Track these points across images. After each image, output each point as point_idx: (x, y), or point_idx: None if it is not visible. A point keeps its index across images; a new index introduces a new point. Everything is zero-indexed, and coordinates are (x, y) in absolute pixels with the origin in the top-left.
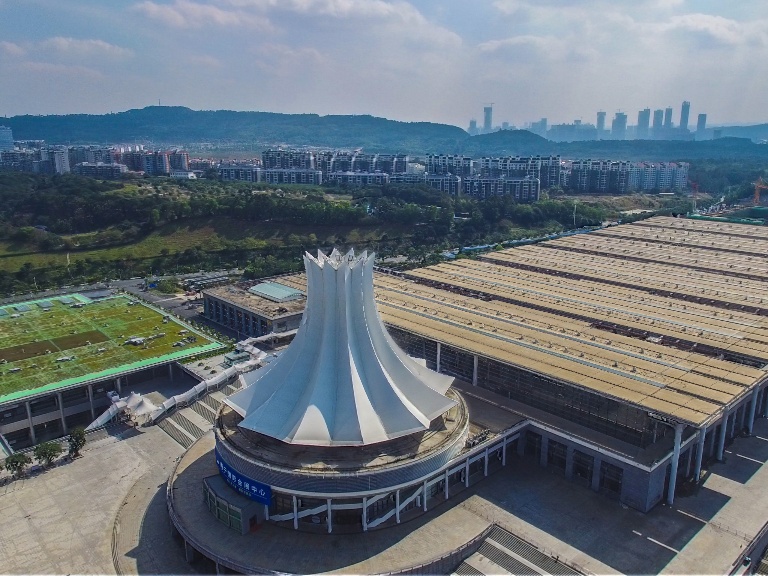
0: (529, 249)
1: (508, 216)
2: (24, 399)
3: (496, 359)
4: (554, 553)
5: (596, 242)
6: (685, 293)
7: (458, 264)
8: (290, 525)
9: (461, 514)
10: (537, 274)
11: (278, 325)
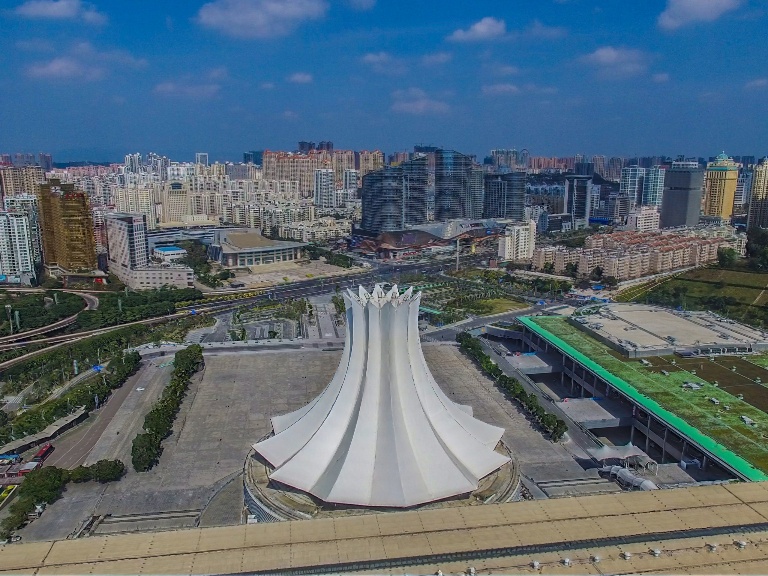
0: None
1: None
2: None
3: None
4: None
5: None
6: None
7: None
8: None
9: None
10: None
11: None
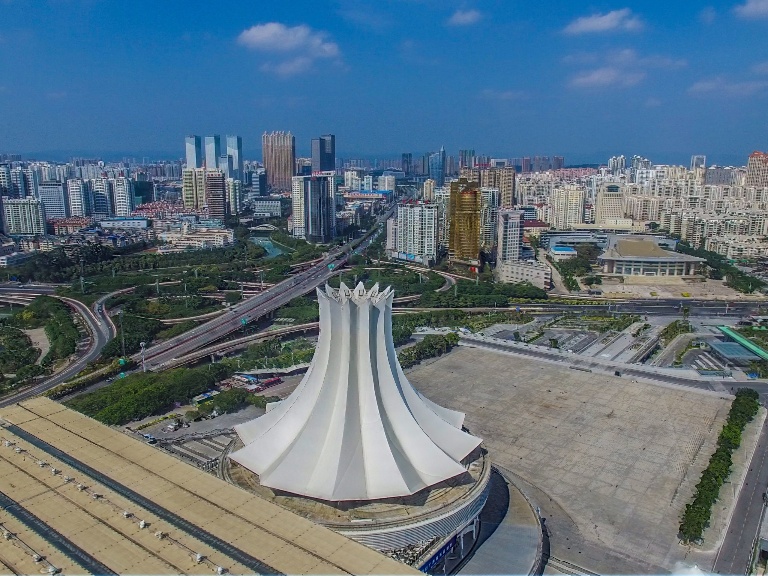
0: None
1: None
2: None
3: None
4: None
5: None
6: None
7: None
8: None
9: None
10: None
11: None
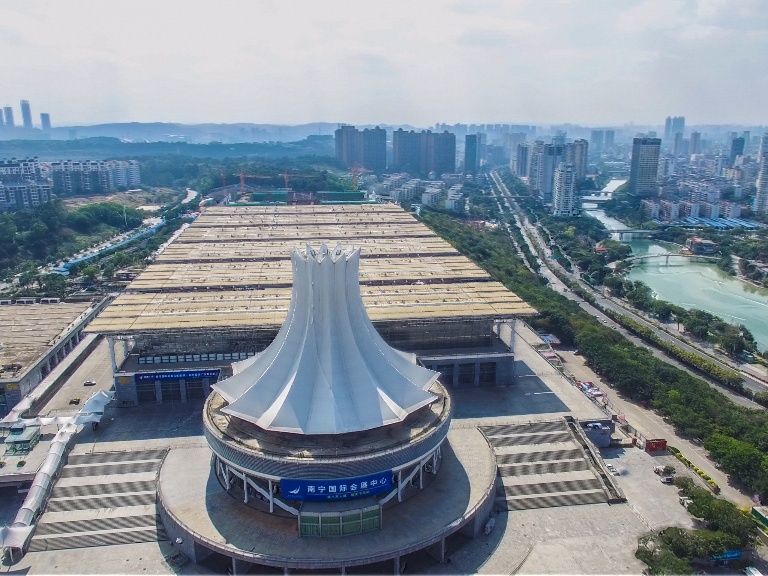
0: (183, 247)
1: (62, 224)
2: None
3: (383, 320)
4: (526, 421)
5: (219, 233)
6: (366, 254)
7: (160, 270)
8: (396, 501)
9: (456, 433)
10: (247, 263)
11: (23, 386)
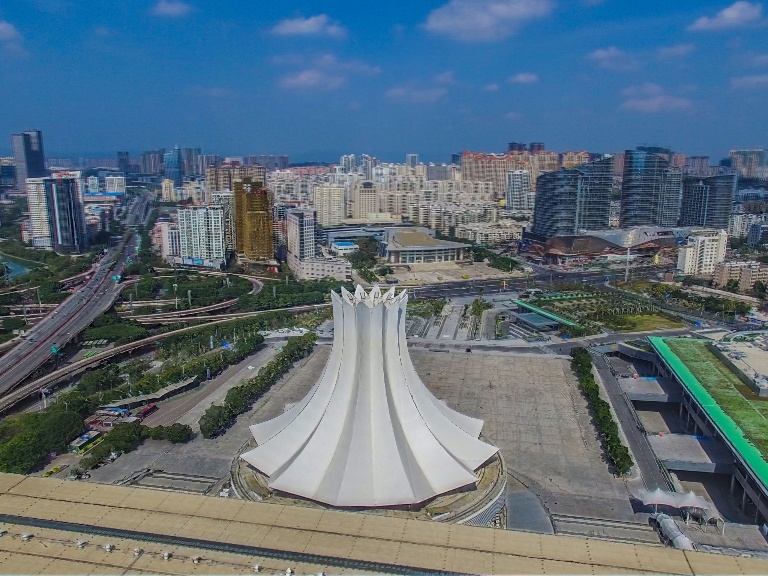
0: None
1: None
2: (733, 449)
3: None
4: None
5: None
6: None
7: None
8: None
9: None
10: None
11: None
